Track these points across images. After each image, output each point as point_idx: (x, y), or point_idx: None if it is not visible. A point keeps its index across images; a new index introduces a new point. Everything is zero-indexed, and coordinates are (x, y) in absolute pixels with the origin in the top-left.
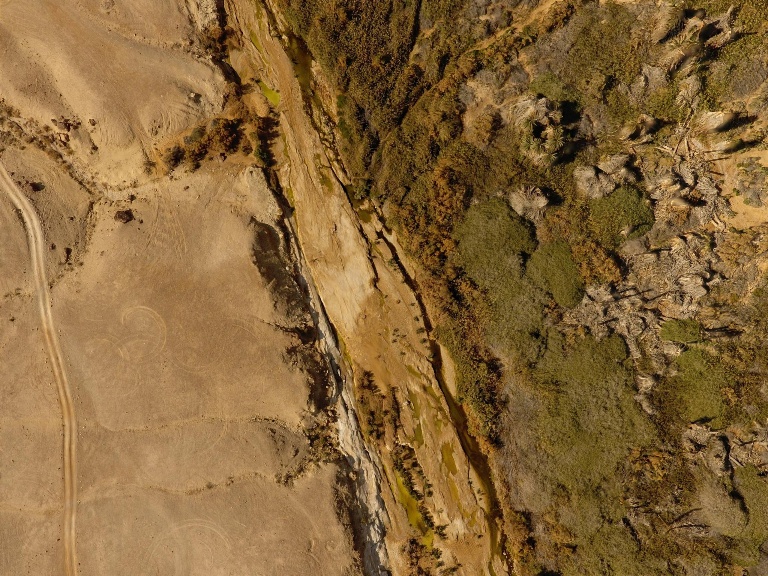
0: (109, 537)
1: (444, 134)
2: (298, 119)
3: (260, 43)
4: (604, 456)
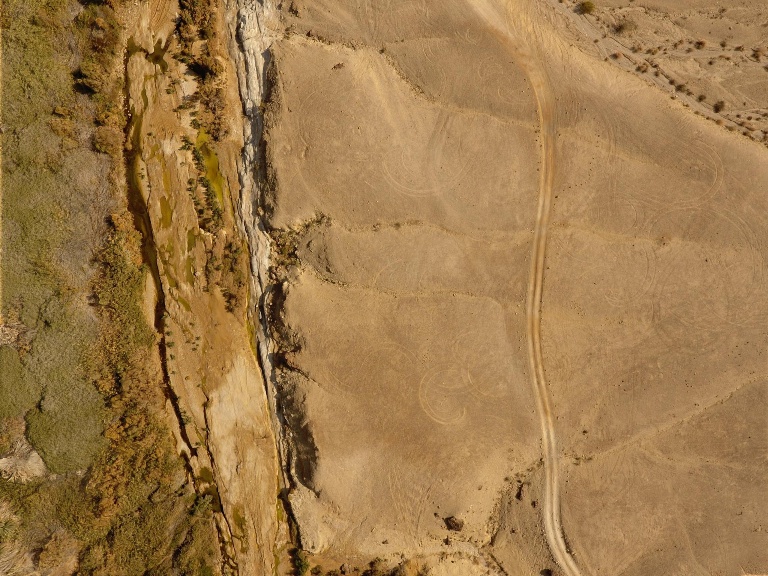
0: (504, 192)
1: (97, 553)
2: None
3: None
4: (3, 195)
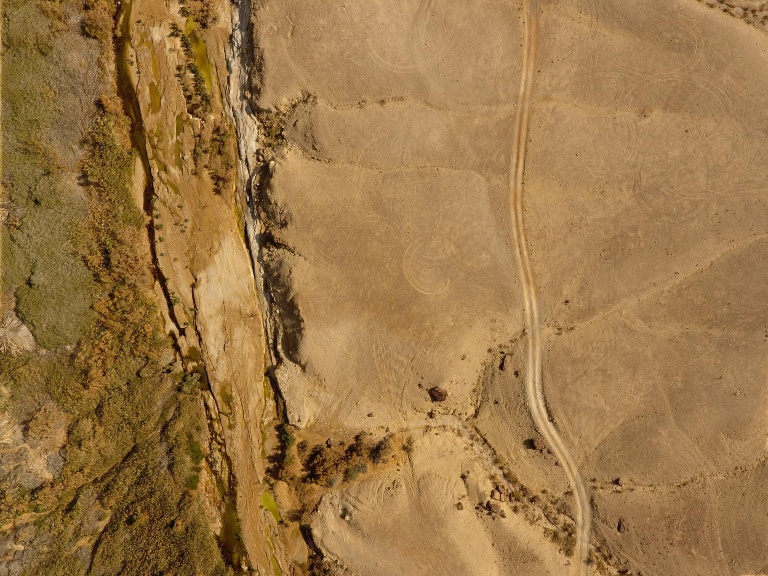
0: (487, 67)
1: (86, 426)
2: (245, 472)
3: (272, 566)
4: None
